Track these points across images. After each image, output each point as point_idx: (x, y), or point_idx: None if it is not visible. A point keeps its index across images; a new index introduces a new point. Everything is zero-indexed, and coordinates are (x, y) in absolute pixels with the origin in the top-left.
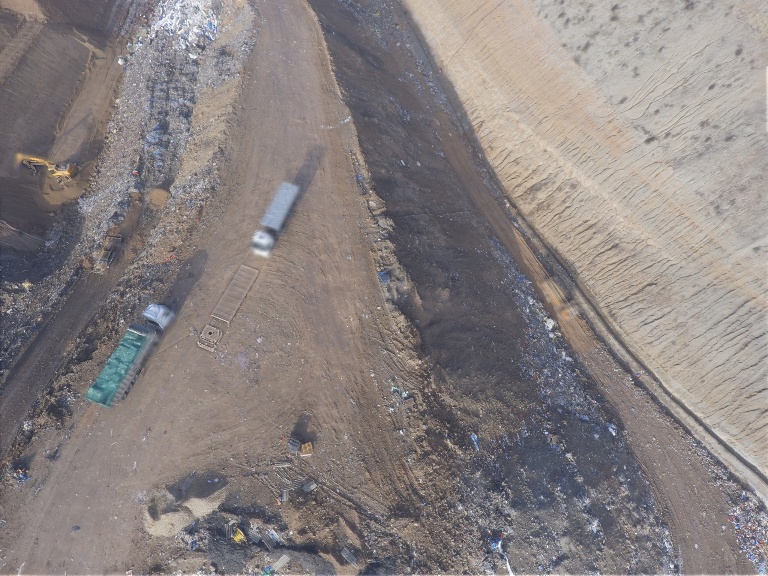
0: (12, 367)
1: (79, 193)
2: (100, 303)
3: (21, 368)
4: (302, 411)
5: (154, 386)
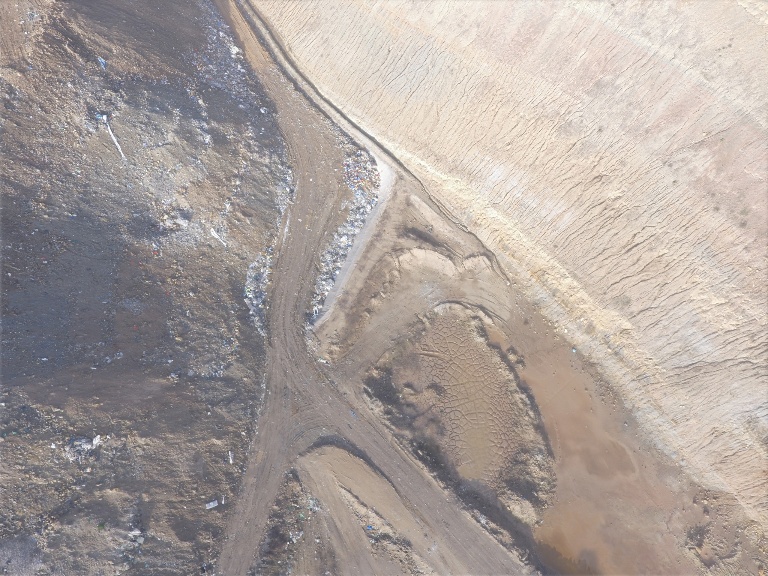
0: None
1: None
2: None
3: None
4: None
5: None
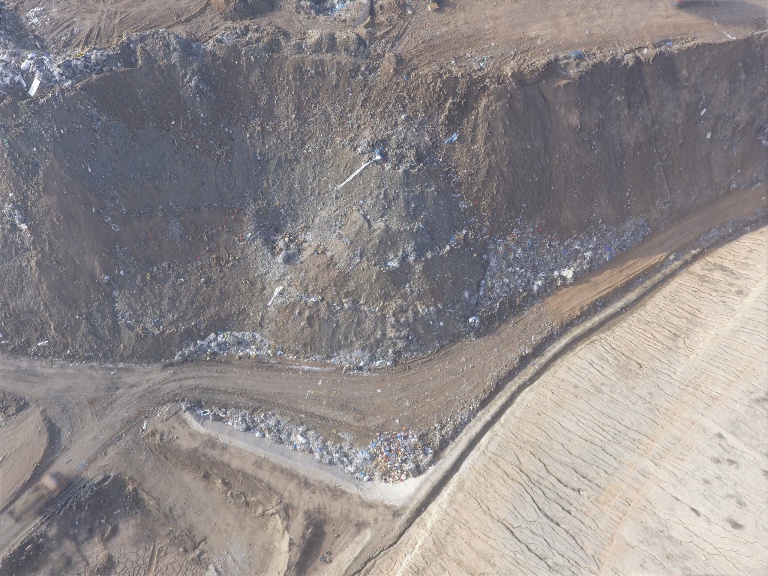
0: None
1: None
2: None
3: None
4: (459, 4)
5: None
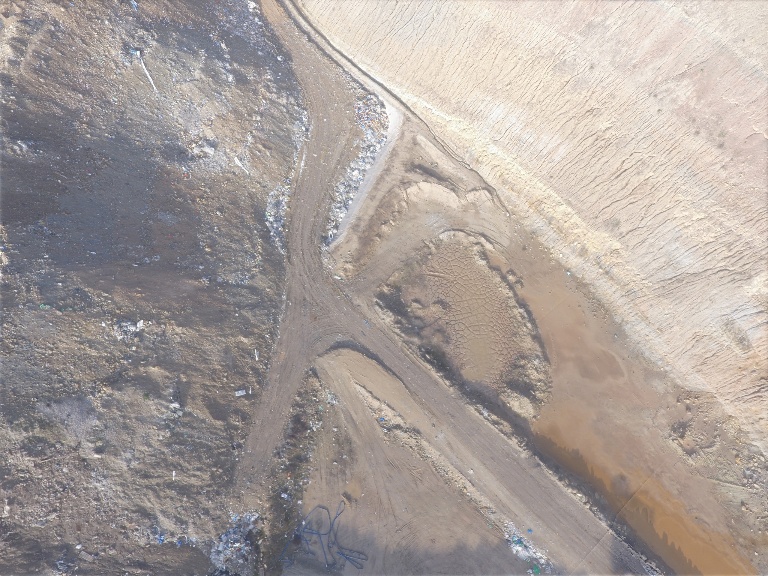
0: None
1: None
2: None
3: None
4: None
5: None
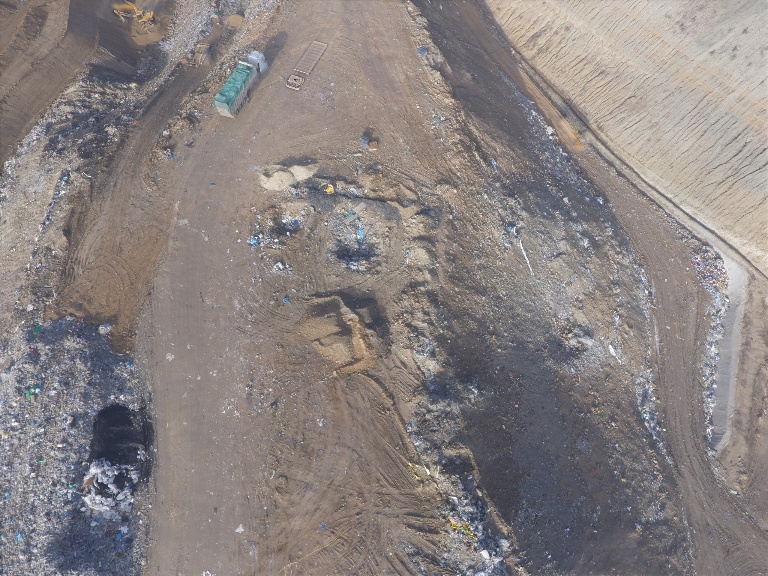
0: (145, 107)
1: (160, 38)
2: (201, 81)
3: (152, 108)
4: (368, 125)
5: (257, 108)
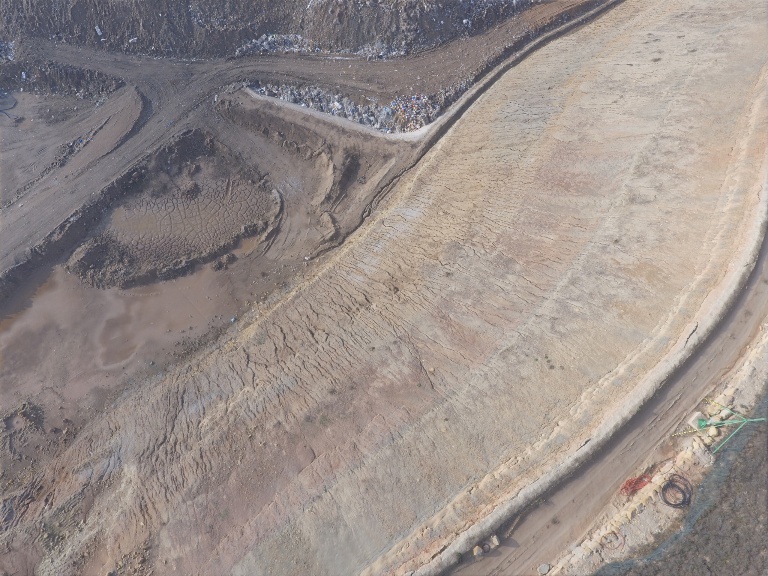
0: None
1: None
2: None
3: None
4: None
5: None
